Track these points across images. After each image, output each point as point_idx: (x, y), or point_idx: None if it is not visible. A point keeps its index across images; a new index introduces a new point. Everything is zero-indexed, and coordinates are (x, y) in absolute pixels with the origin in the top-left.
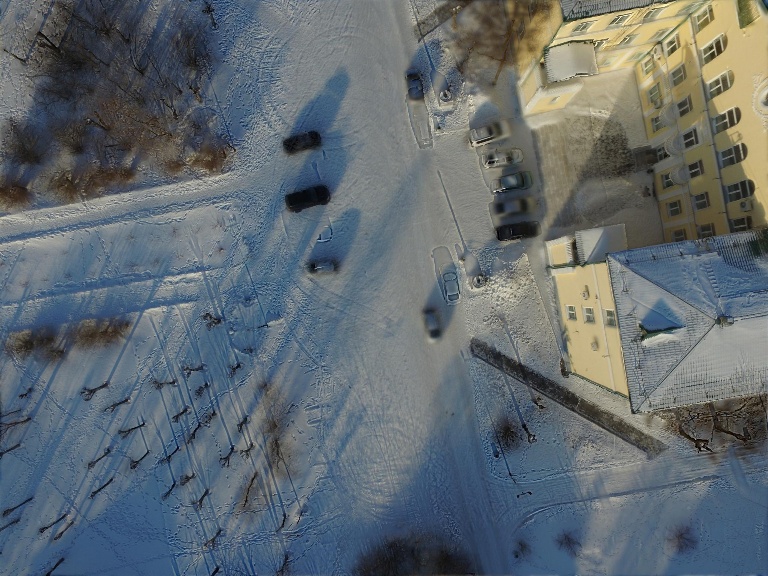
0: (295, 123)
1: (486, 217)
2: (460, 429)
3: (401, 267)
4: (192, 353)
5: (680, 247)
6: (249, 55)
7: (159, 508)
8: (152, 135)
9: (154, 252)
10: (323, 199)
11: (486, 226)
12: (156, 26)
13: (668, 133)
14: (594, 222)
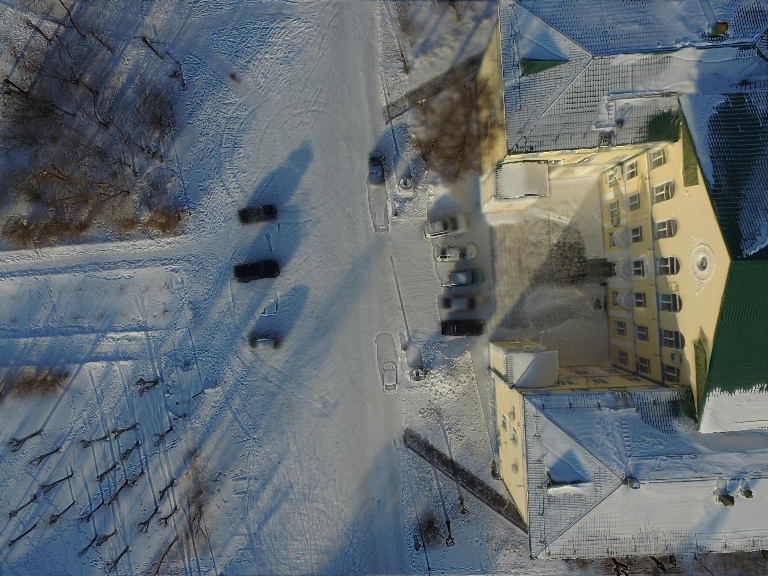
0: (253, 192)
1: (434, 309)
2: (384, 517)
3: (343, 349)
4: (127, 410)
5: (599, 398)
6: (215, 119)
7: (79, 559)
8: (103, 197)
9: (100, 306)
10: (271, 274)
11: (433, 318)
12: (125, 80)
13: (621, 254)
14: (541, 328)
